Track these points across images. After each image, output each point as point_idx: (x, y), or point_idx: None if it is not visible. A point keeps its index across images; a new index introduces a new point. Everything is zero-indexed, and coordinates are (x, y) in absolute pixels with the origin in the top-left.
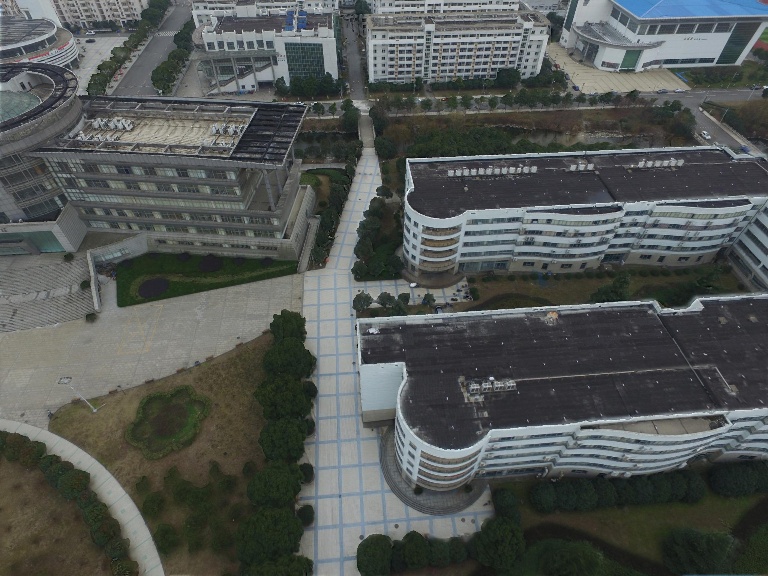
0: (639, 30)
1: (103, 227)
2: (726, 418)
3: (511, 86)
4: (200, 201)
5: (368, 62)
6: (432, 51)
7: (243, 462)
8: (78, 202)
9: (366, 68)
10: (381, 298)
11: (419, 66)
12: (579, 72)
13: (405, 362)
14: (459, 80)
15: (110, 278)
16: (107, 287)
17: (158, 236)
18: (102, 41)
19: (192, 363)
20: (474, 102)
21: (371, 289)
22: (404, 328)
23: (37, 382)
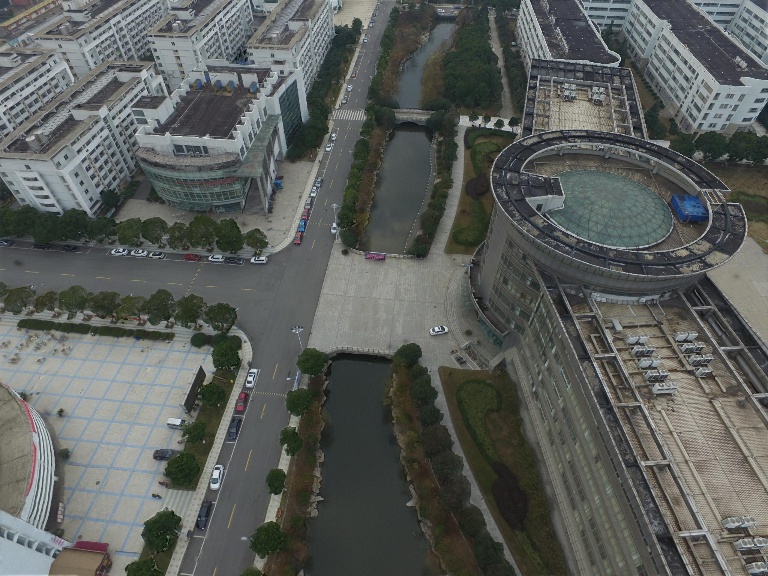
0: None
1: None
2: (724, 31)
3: None
4: None
5: None
6: None
7: (765, 180)
8: None
9: None
10: None
11: None
12: None
13: (736, 80)
14: None
15: None
16: None
17: None
18: None
19: None
20: None
21: None
22: None
23: (762, 276)
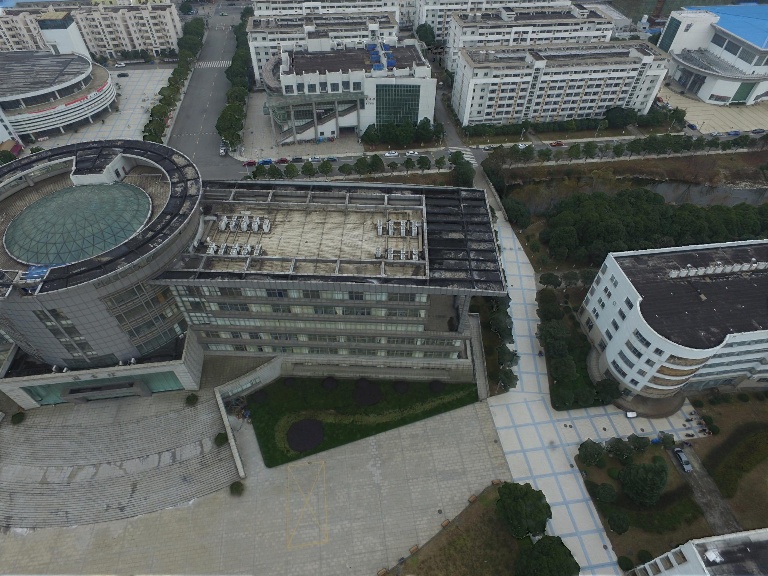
0: (756, 61)
1: (224, 349)
2: None
3: (624, 127)
4: (367, 323)
5: (457, 100)
6: (538, 89)
7: None
8: (201, 327)
9: (451, 105)
10: (616, 447)
11: (520, 105)
12: (686, 106)
13: None
14: (571, 122)
15: (242, 420)
16: (243, 435)
17: (297, 359)
18: (136, 75)
19: (393, 559)
20: (597, 150)
21: (579, 422)
22: (753, 549)
23: None
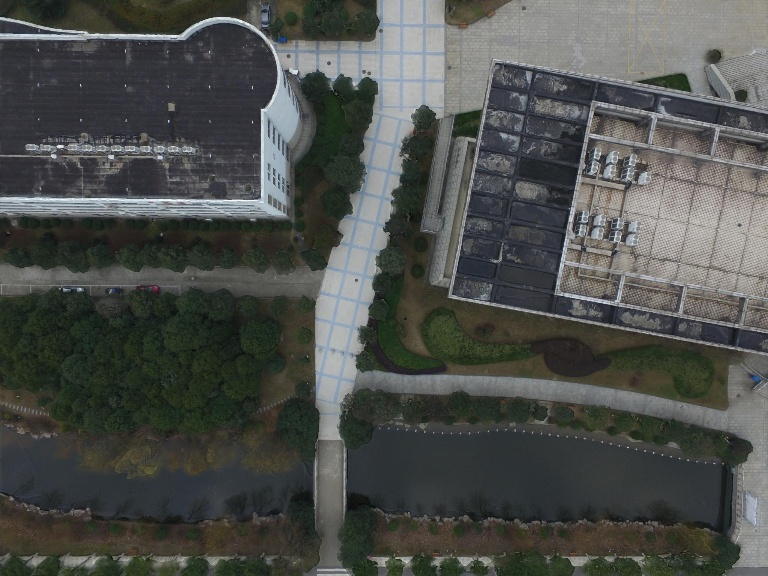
0: None
1: None
2: None
3: None
4: None
5: None
6: None
7: None
8: None
9: None
10: None
11: None
12: None
13: None
14: None
15: None
16: None
17: None
18: None
19: None
20: None
21: (353, 74)
22: None
23: None
